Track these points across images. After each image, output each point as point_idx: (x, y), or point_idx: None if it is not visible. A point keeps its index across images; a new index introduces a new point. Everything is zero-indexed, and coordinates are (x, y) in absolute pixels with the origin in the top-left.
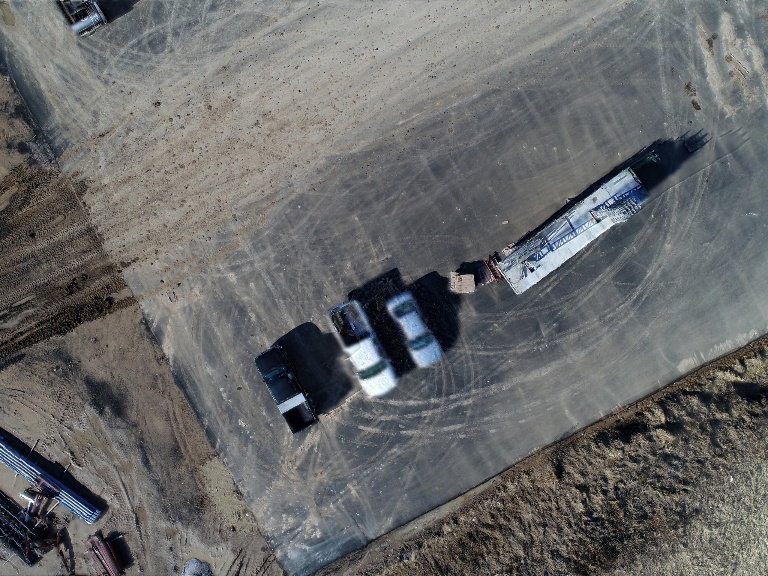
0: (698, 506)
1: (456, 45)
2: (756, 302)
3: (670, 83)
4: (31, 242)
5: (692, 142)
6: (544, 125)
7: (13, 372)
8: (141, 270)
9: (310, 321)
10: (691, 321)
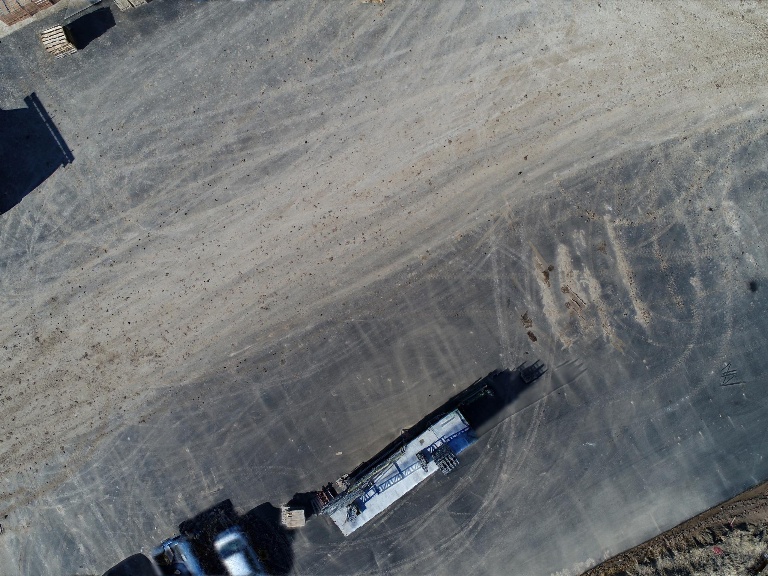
0: None
1: (289, 277)
2: (593, 531)
3: (506, 314)
4: None
5: (528, 373)
6: (378, 356)
7: None
8: None
9: (140, 552)
10: (527, 550)
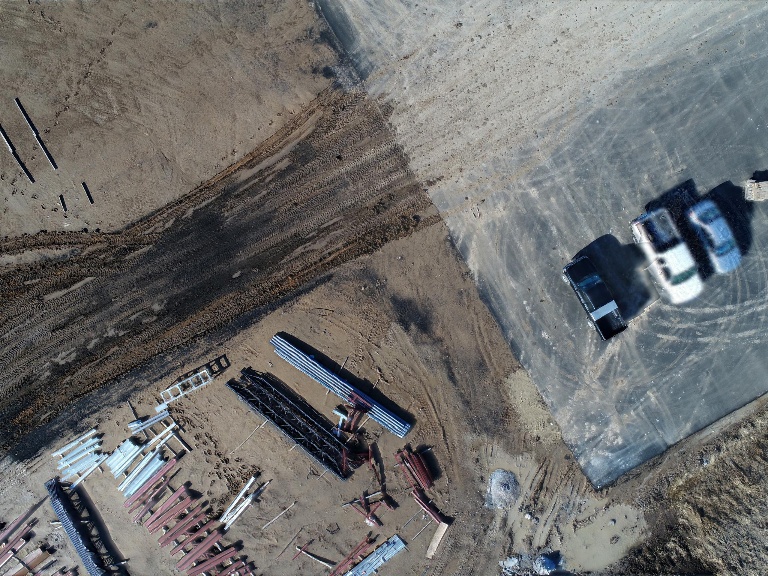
0: None
1: None
2: None
3: None
4: (338, 164)
5: None
6: None
7: (322, 292)
8: (446, 188)
9: (609, 233)
10: None
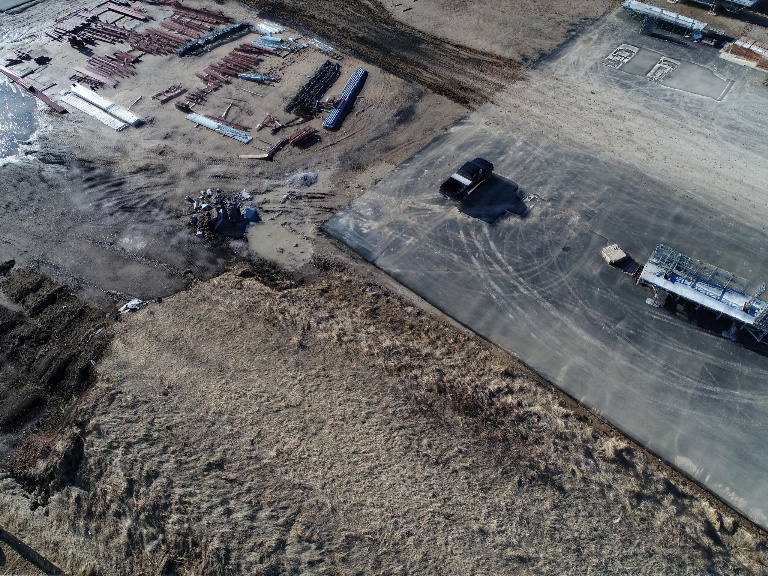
0: (567, 488)
1: (767, 204)
2: None
3: None
4: (478, 71)
5: None
6: None
7: (400, 81)
8: (494, 109)
9: (519, 185)
10: (730, 451)
